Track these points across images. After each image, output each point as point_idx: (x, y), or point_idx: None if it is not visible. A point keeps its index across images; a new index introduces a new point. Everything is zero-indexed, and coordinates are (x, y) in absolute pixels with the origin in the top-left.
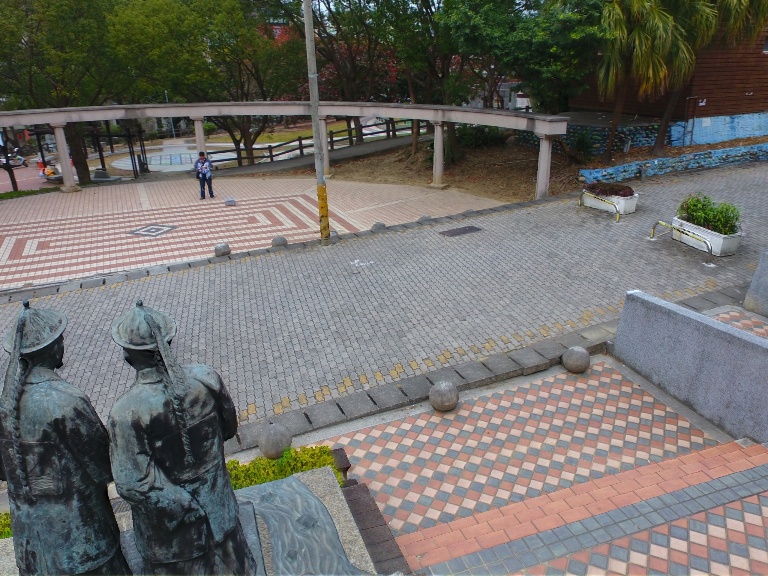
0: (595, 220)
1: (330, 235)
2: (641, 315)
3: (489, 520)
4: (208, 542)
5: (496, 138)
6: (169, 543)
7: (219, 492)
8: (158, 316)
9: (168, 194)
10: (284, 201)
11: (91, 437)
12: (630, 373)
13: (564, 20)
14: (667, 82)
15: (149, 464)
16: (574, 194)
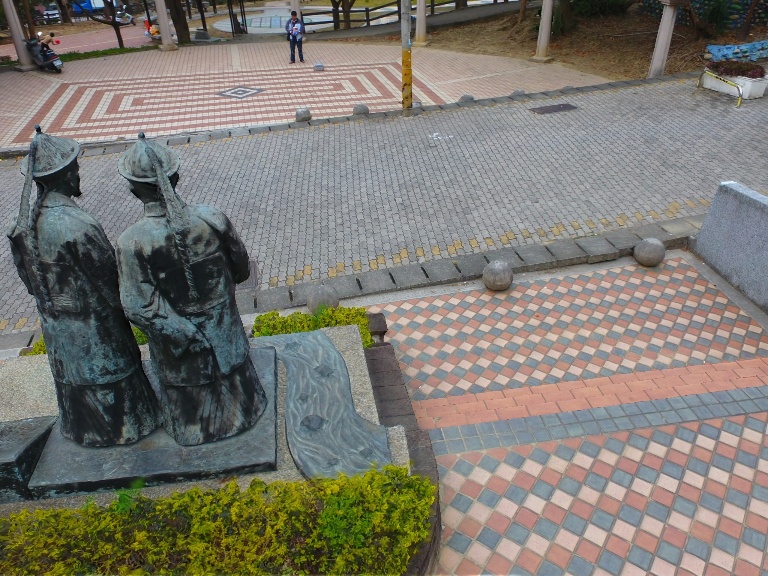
0: (711, 104)
1: (413, 106)
2: (732, 209)
3: (516, 396)
4: (214, 373)
5: (616, 5)
6: (178, 368)
7: (226, 329)
8: (161, 150)
9: (259, 56)
10: (373, 69)
11: (103, 263)
12: (708, 272)
13: None
14: None
15: (154, 293)
16: (694, 74)
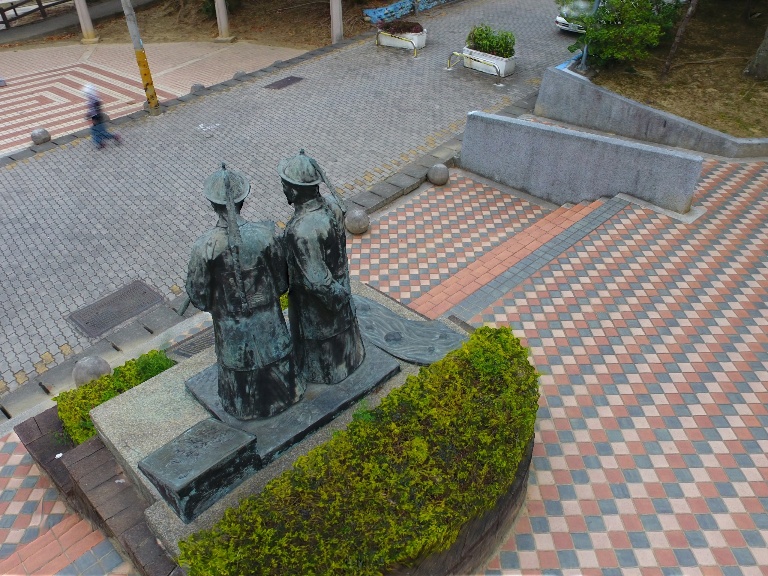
0: (397, 58)
1: None
2: (482, 130)
3: None
4: (350, 318)
5: None
6: (332, 323)
7: None
8: None
9: None
10: (64, 74)
11: (282, 258)
12: (477, 177)
13: None
14: None
15: None
16: (366, 35)
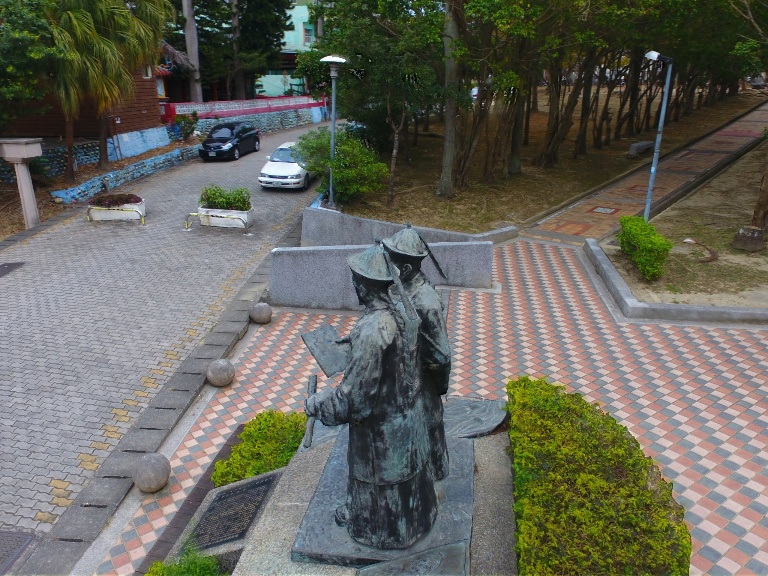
0: (123, 228)
1: None
2: (290, 263)
3: None
4: None
5: None
6: None
7: None
8: None
9: None
10: None
11: None
12: (293, 309)
13: (16, 39)
14: (121, 100)
15: None
16: (65, 215)
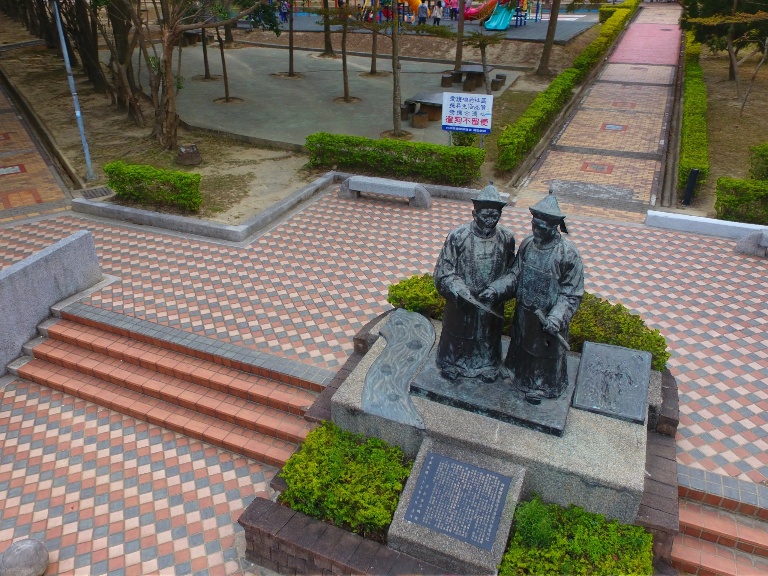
0: None
1: None
2: None
3: None
4: None
5: None
6: None
7: None
8: None
9: None
10: None
11: None
12: None
13: None
14: None
15: None
16: None
